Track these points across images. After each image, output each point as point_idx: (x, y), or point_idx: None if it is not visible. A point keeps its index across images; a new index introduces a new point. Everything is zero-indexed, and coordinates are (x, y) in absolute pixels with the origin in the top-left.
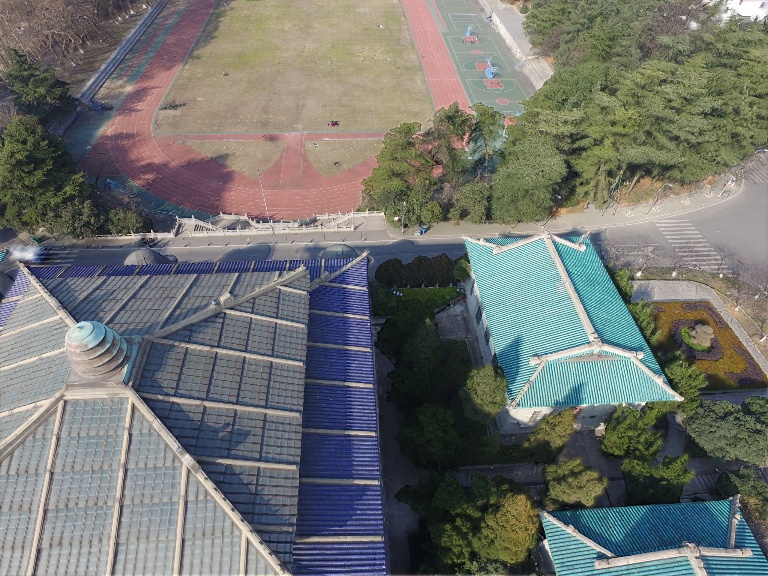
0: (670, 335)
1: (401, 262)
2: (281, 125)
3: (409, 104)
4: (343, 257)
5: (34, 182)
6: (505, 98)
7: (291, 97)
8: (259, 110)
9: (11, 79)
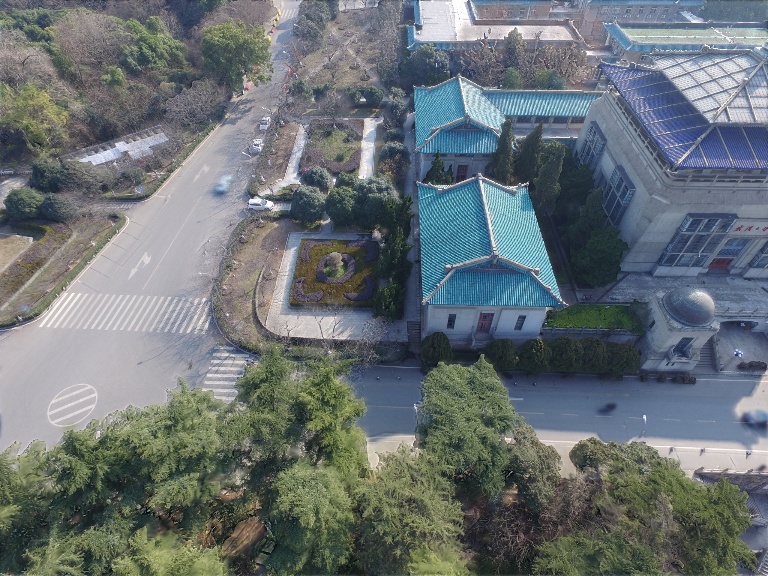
0: (356, 272)
1: (616, 357)
2: None
3: None
4: (691, 288)
5: None
6: None
7: None
8: None
9: None
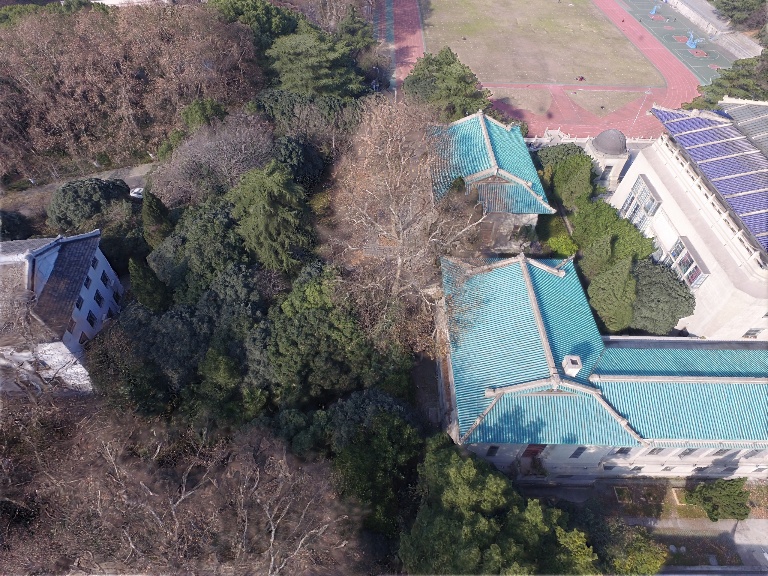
0: None
1: None
2: (537, 78)
3: (635, 66)
4: None
5: (473, 91)
6: (716, 64)
7: (531, 58)
8: (511, 66)
9: (344, 30)
